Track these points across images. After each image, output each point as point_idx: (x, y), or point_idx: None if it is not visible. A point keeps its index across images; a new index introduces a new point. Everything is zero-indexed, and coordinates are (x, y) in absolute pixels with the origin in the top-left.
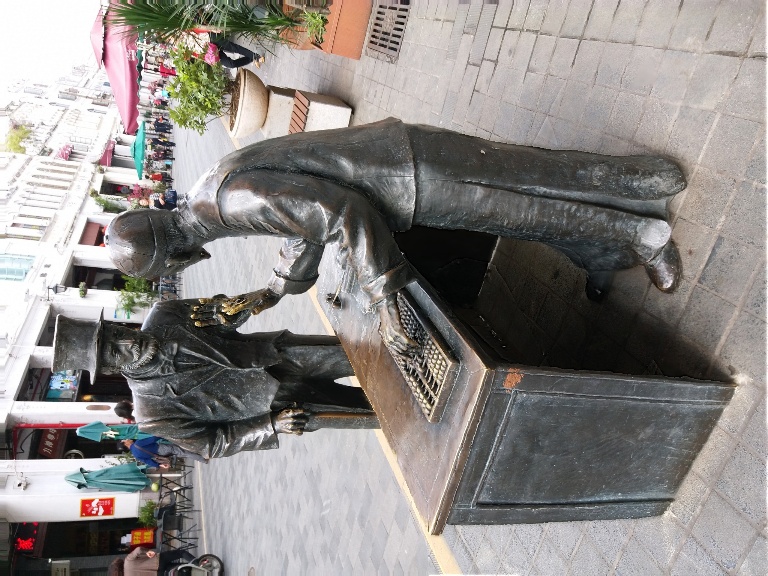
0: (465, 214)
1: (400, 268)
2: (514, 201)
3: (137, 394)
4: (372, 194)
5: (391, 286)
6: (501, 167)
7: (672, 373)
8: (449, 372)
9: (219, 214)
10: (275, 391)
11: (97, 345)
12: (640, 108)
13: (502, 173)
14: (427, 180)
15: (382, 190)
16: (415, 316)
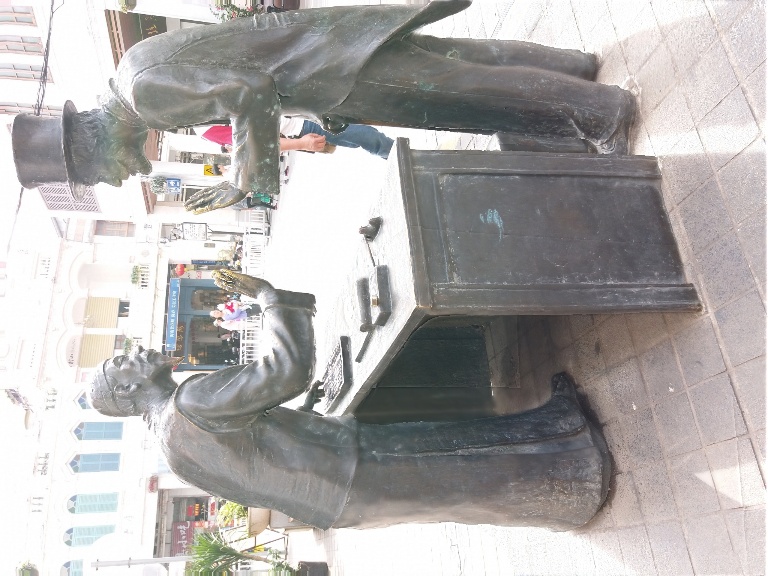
0: None
1: None
2: None
3: None
4: None
5: None
6: None
7: (512, 394)
8: None
9: None
10: None
11: None
12: (627, 568)
13: None
14: None
15: None
16: None
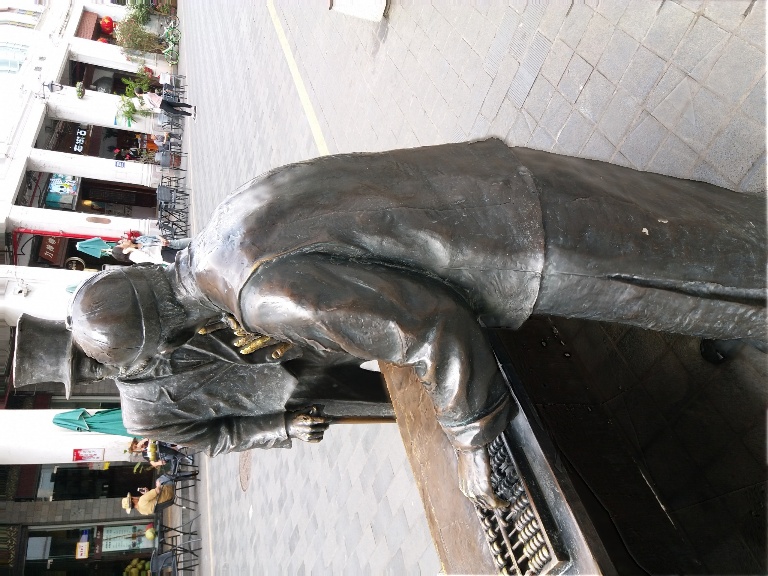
0: (598, 313)
1: (501, 408)
2: (673, 303)
3: (125, 395)
4: (473, 290)
5: (485, 435)
6: (667, 255)
7: None
8: (552, 569)
9: (241, 320)
10: (292, 390)
11: (71, 367)
12: None
13: (667, 265)
14: (557, 274)
15: (488, 283)
16: (503, 441)
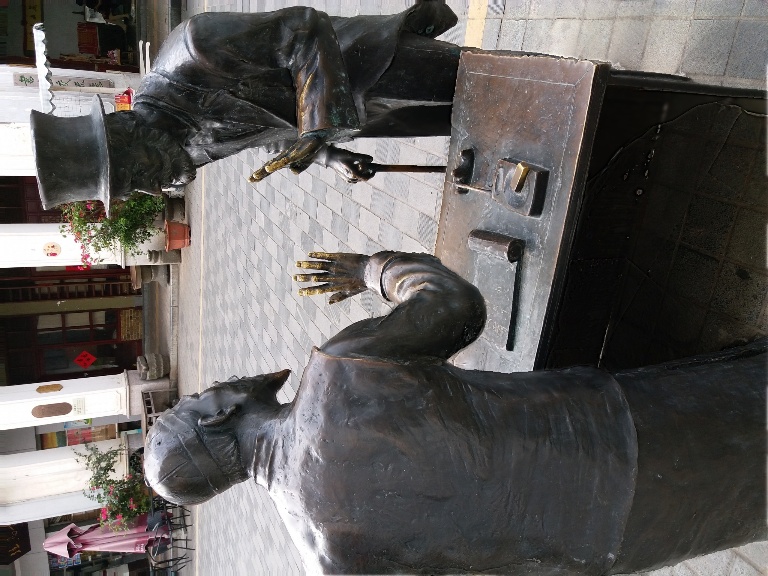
0: None
1: None
2: None
3: None
4: None
5: None
6: None
7: None
8: None
9: None
10: None
11: (107, 217)
12: None
13: None
14: None
15: None
16: None
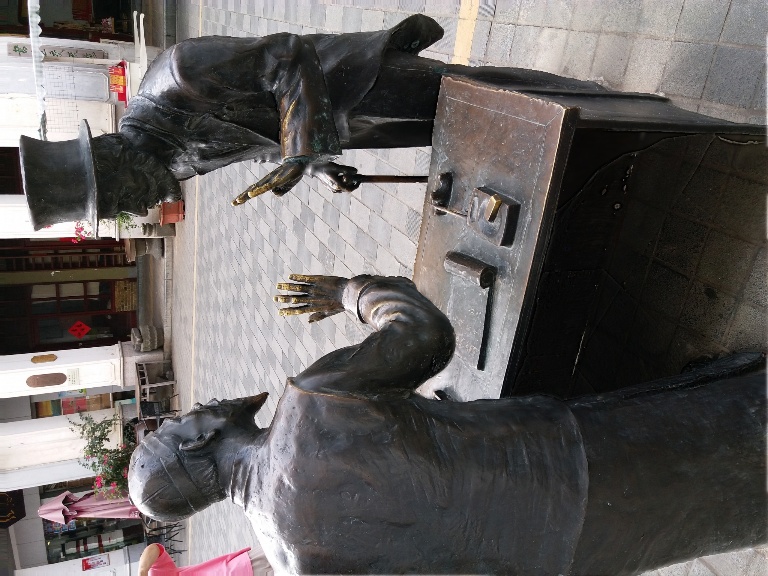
0: None
1: None
2: None
3: None
4: None
5: None
6: None
7: None
8: None
9: None
10: None
11: None
12: None
13: None
14: None
15: None
16: None
